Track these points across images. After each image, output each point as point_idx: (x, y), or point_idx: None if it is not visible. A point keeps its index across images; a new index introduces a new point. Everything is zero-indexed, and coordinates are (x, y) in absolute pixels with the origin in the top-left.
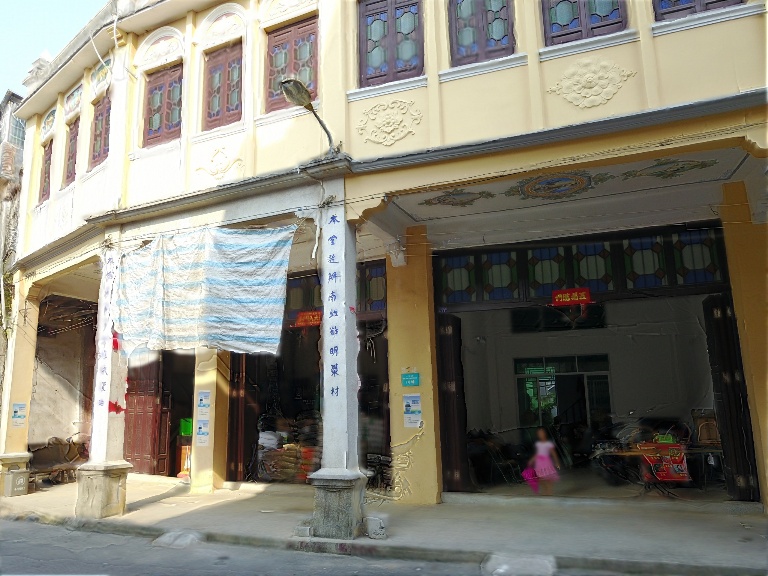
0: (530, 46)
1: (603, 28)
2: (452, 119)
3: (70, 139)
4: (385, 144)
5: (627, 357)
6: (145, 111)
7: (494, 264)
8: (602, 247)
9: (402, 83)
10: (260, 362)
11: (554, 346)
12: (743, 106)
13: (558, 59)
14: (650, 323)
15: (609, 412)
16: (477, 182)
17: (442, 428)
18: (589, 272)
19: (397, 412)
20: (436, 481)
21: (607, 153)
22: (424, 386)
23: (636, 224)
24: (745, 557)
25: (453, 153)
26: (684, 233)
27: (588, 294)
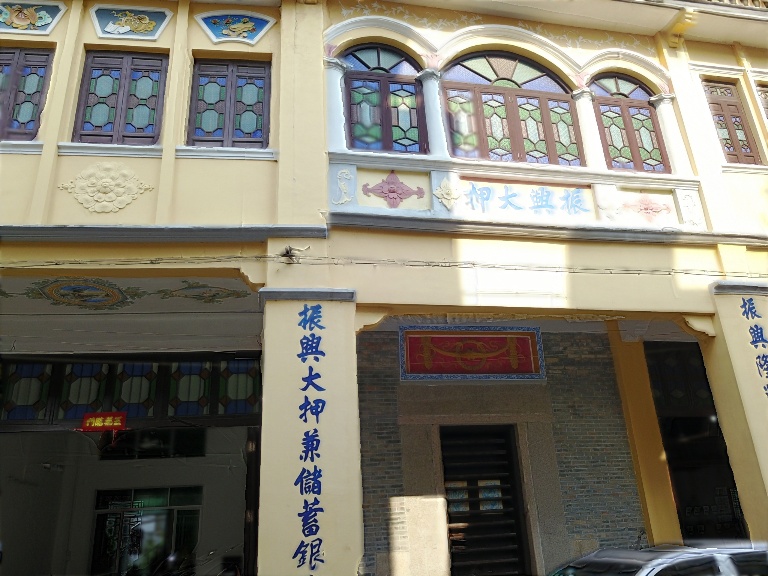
0: (48, 136)
1: (134, 139)
2: None
3: None
4: None
5: (222, 489)
6: None
7: (24, 377)
8: (150, 368)
9: None
10: None
11: (147, 476)
12: (239, 239)
13: (77, 157)
14: (219, 454)
15: (189, 553)
16: None
17: None
18: (132, 394)
19: None
20: None
21: (95, 262)
22: None
23: (187, 347)
24: None
25: None
26: (233, 361)
27: (124, 419)
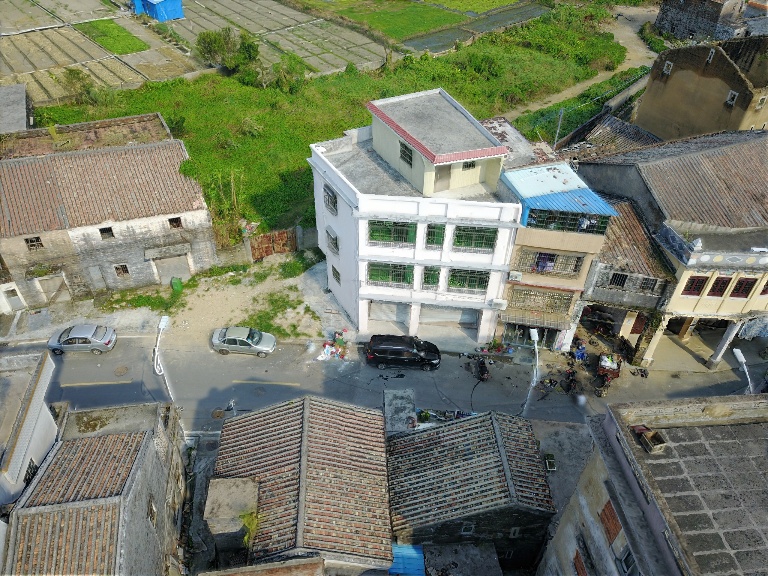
0: None
1: None
2: None
3: (716, 280)
4: None
5: None
6: (764, 285)
7: None
8: None
9: None
10: None
11: None
12: None
13: None
14: None
15: None
16: None
17: None
18: None
19: None
20: None
21: None
22: None
23: None
24: None
25: None
26: None
27: None
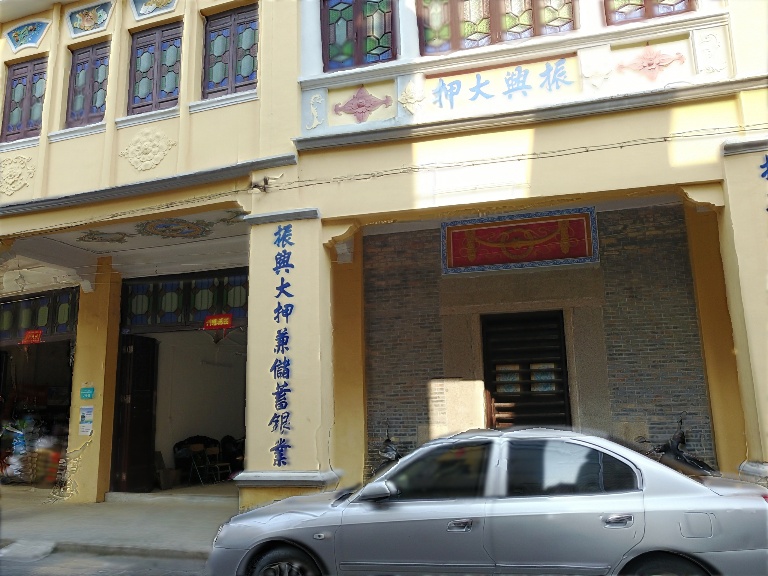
0: (108, 116)
1: (166, 103)
2: (56, 174)
3: None
4: (7, 194)
5: None
6: None
7: (167, 292)
8: (245, 279)
9: (26, 141)
10: (7, 375)
11: None
12: (232, 176)
13: (127, 128)
14: None
15: None
16: (56, 231)
17: (114, 436)
18: (235, 300)
19: (75, 422)
20: (96, 483)
21: (135, 211)
22: (96, 399)
23: None
24: (200, 543)
25: (41, 205)
26: None
27: (230, 320)
